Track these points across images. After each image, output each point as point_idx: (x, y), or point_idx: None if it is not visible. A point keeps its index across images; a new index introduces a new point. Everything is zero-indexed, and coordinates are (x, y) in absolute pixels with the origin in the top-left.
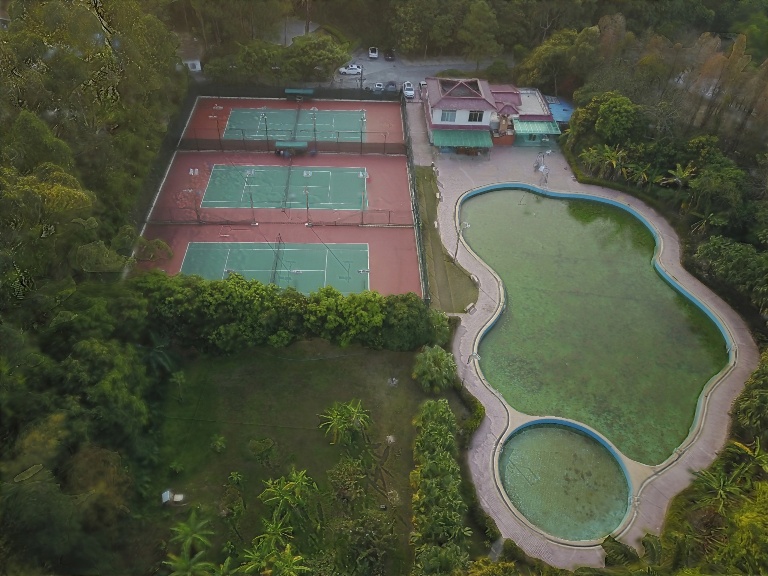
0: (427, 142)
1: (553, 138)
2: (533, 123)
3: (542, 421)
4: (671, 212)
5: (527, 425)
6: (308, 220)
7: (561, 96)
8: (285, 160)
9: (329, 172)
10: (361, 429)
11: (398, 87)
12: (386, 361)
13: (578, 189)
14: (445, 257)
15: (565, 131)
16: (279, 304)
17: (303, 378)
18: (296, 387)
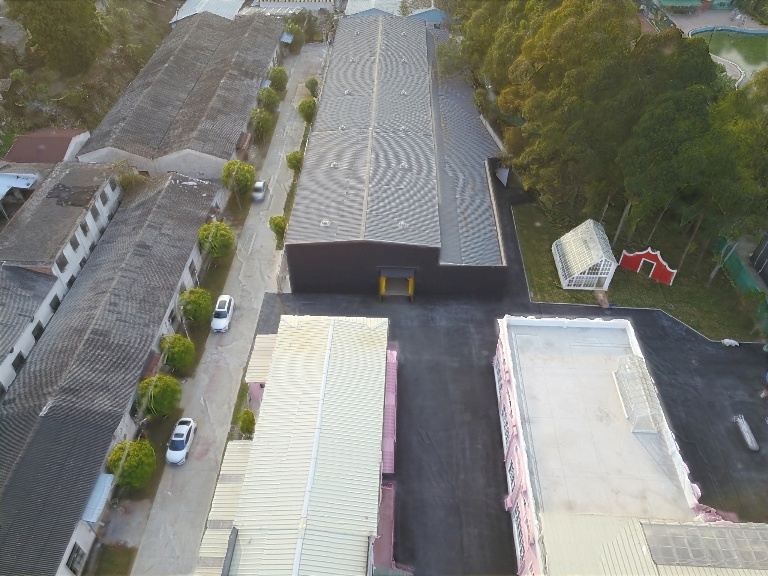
0: None
1: (736, 5)
2: None
3: None
4: None
5: None
6: None
7: None
8: None
9: None
10: None
11: None
12: None
13: (765, 28)
14: None
15: None
16: None
17: None
18: None
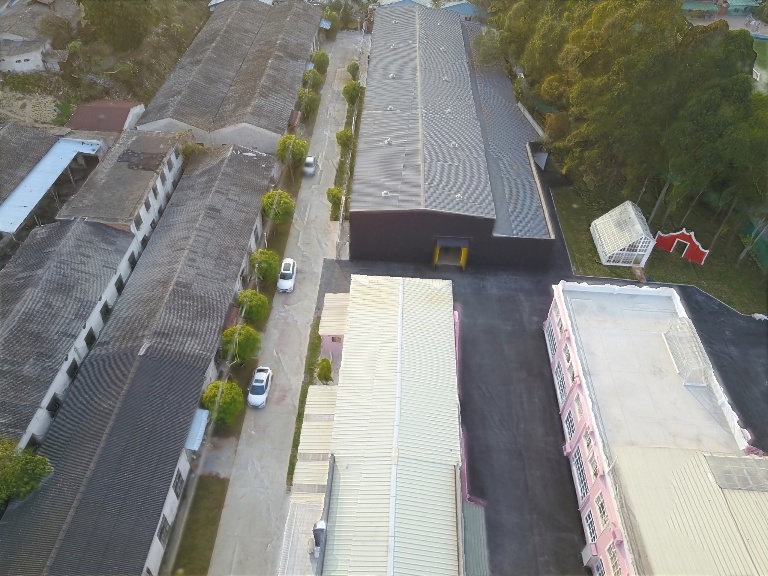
0: None
1: (750, 12)
2: None
3: None
4: None
5: None
6: None
7: None
8: None
9: None
10: None
11: None
12: None
13: None
14: None
15: (762, 4)
16: None
17: None
18: None
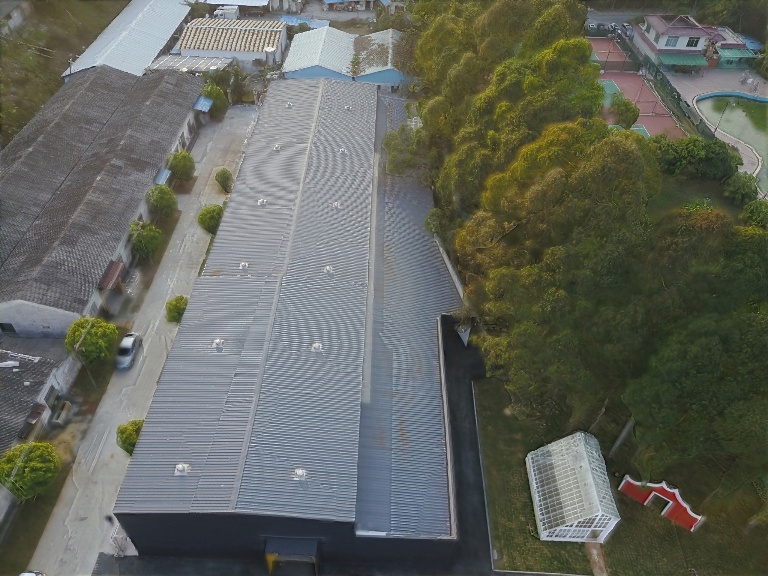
0: (648, 64)
1: (745, 63)
2: (732, 50)
3: None
4: None
5: None
6: None
7: (744, 33)
8: None
9: None
10: None
11: (606, 28)
12: (696, 189)
13: None
14: None
15: None
16: None
17: None
18: None
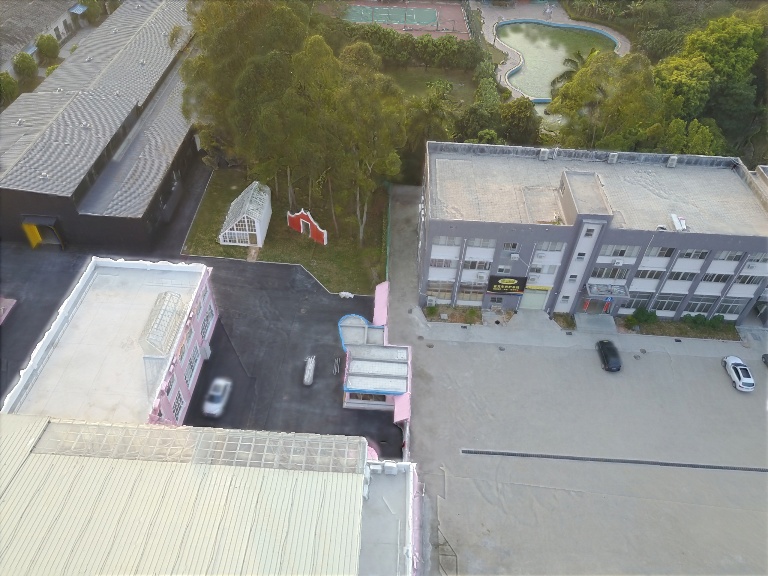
0: None
1: (556, 0)
2: None
3: (542, 100)
4: (628, 32)
5: (534, 102)
6: (405, 26)
7: None
8: (384, 4)
9: (413, 10)
10: (448, 92)
11: None
12: (457, 78)
13: (571, 22)
14: (488, 45)
15: None
16: (402, 38)
17: (413, 82)
18: (410, 84)
